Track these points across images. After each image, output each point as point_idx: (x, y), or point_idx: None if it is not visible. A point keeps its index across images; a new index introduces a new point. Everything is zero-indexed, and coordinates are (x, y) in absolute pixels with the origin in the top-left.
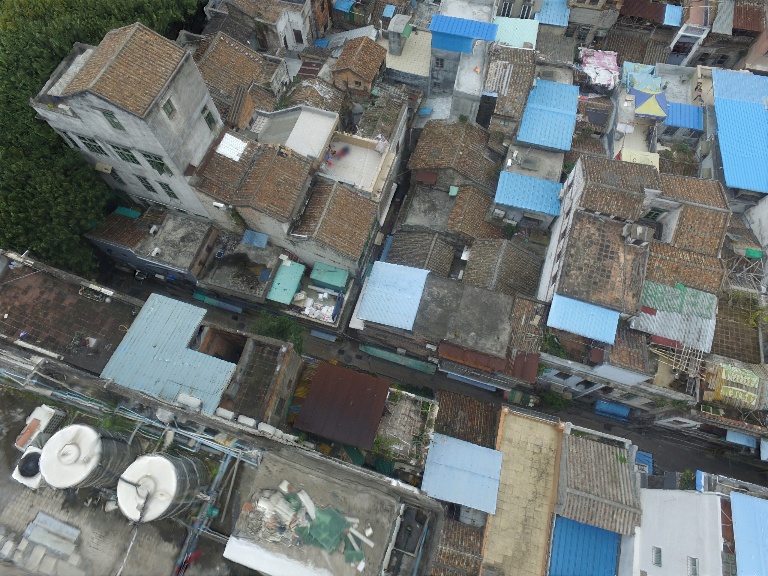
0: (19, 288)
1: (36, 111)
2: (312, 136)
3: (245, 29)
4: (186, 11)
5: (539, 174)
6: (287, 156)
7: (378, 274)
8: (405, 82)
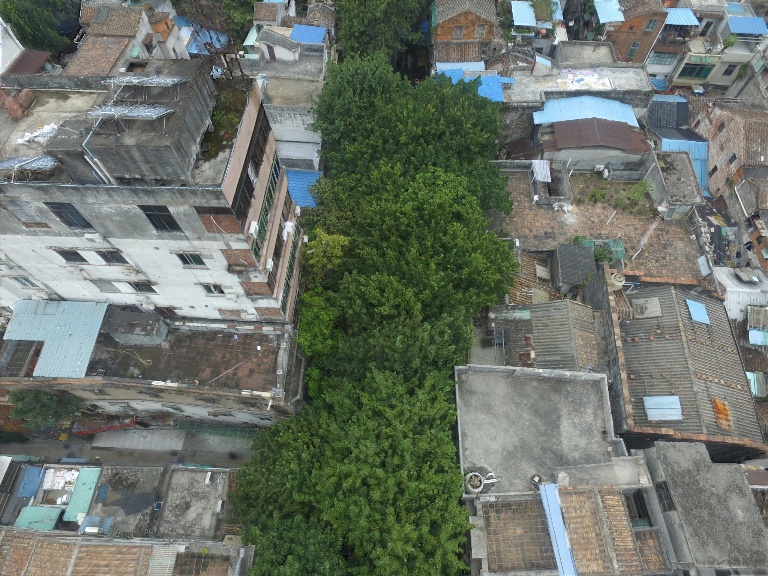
0: (259, 373)
1: None
2: None
3: None
4: None
5: None
6: None
7: None
8: None
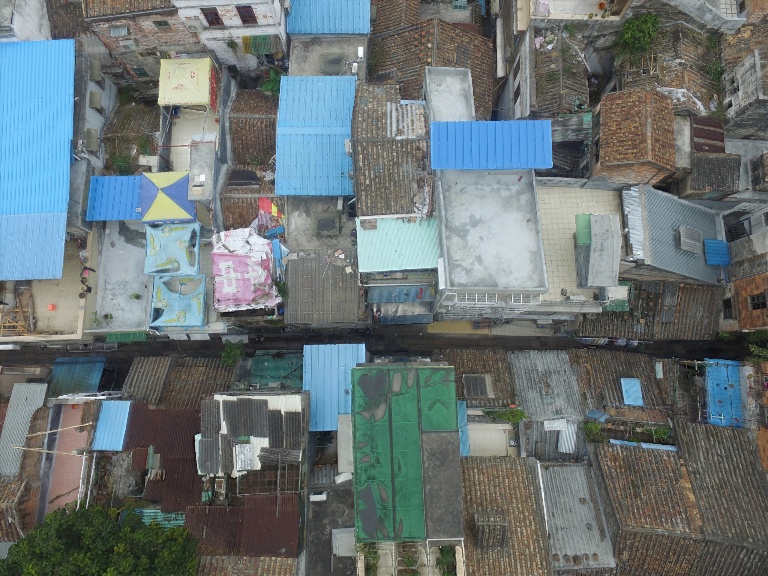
0: None
1: None
2: None
3: None
4: None
5: (318, 54)
6: None
7: None
8: None
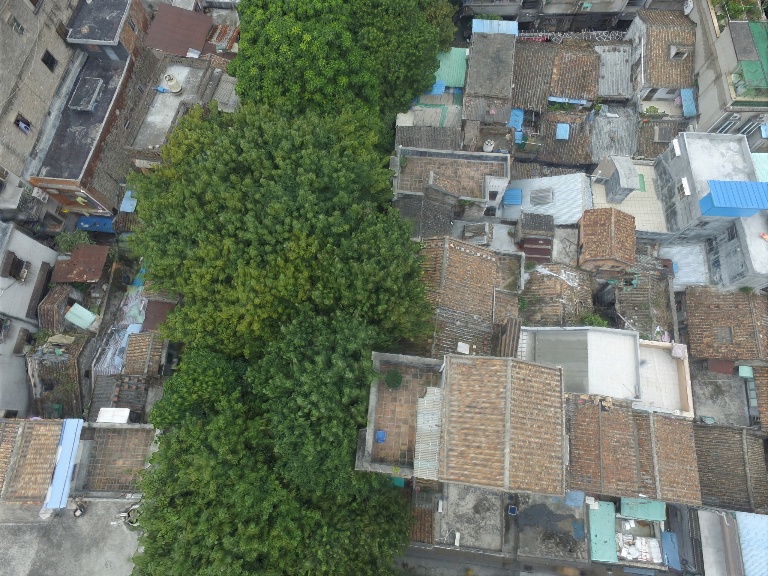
0: None
1: (352, 459)
2: (616, 366)
3: (444, 208)
4: (381, 206)
5: None
6: (609, 408)
7: (749, 531)
8: (639, 237)
